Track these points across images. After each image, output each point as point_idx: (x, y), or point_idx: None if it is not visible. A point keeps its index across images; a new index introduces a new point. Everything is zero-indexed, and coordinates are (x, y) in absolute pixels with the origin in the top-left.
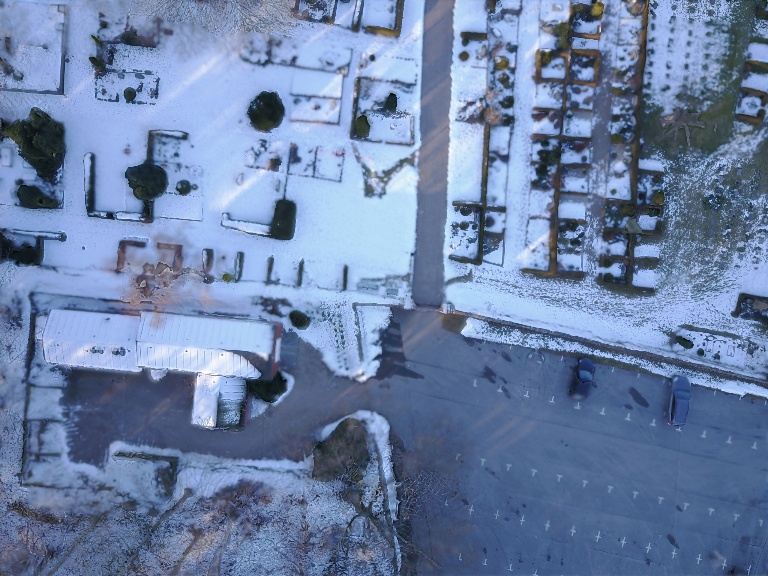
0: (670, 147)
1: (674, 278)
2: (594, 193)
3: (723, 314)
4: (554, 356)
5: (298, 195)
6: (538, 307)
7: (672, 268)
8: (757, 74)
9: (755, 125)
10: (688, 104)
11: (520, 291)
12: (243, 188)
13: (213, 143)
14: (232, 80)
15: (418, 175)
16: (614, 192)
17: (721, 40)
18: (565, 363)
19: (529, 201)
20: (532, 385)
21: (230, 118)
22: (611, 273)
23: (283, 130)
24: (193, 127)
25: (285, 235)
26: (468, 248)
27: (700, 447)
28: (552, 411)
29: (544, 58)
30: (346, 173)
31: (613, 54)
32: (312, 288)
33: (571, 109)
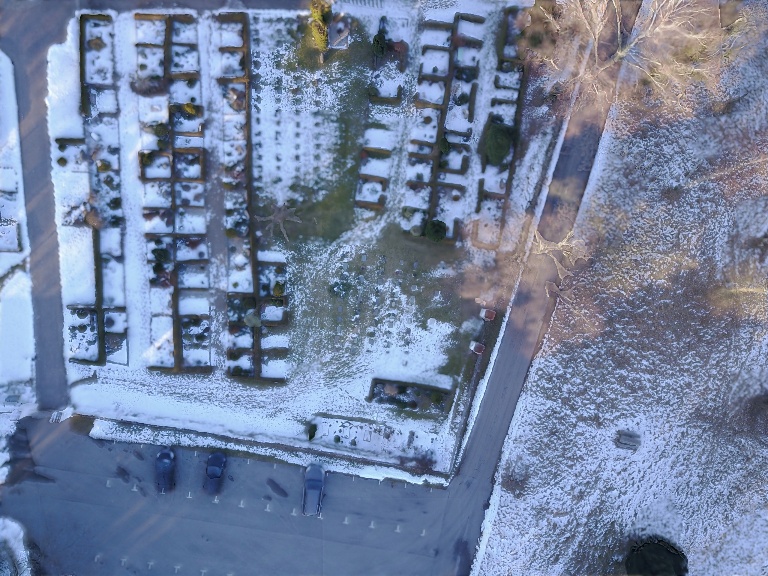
0: (290, 238)
1: (305, 367)
2: (216, 287)
3: (357, 400)
4: (187, 452)
5: None
6: (168, 404)
7: (302, 357)
8: (377, 159)
9: (377, 210)
10: (303, 195)
11: (149, 389)
12: None
13: None
14: None
15: (31, 281)
16: (236, 285)
17: (331, 130)
18: (199, 458)
19: (150, 299)
20: (167, 482)
21: None
22: (240, 366)
23: None
24: None
25: None
26: (88, 350)
27: (343, 534)
28: (190, 507)
29: (143, 160)
30: None
31: (220, 150)
32: None
33: (182, 207)
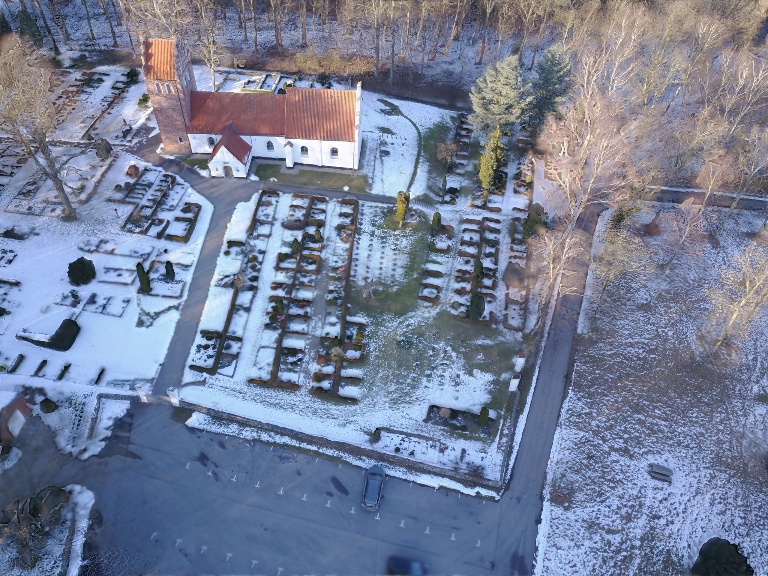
0: (371, 310)
1: (374, 393)
2: (312, 334)
3: (416, 421)
4: (265, 446)
5: (85, 323)
6: (257, 408)
7: (372, 386)
8: (434, 278)
9: (434, 303)
10: None
11: (244, 396)
12: (45, 316)
13: (36, 290)
14: (67, 259)
15: (180, 315)
16: (327, 334)
17: (404, 257)
18: (274, 453)
19: (262, 337)
20: (240, 470)
21: (55, 278)
22: (322, 387)
23: (90, 286)
24: (26, 281)
25: (61, 341)
26: (206, 361)
27: (399, 536)
28: (256, 495)
29: (280, 256)
30: (127, 312)
31: (330, 259)
32: (69, 382)
33: (299, 285)
